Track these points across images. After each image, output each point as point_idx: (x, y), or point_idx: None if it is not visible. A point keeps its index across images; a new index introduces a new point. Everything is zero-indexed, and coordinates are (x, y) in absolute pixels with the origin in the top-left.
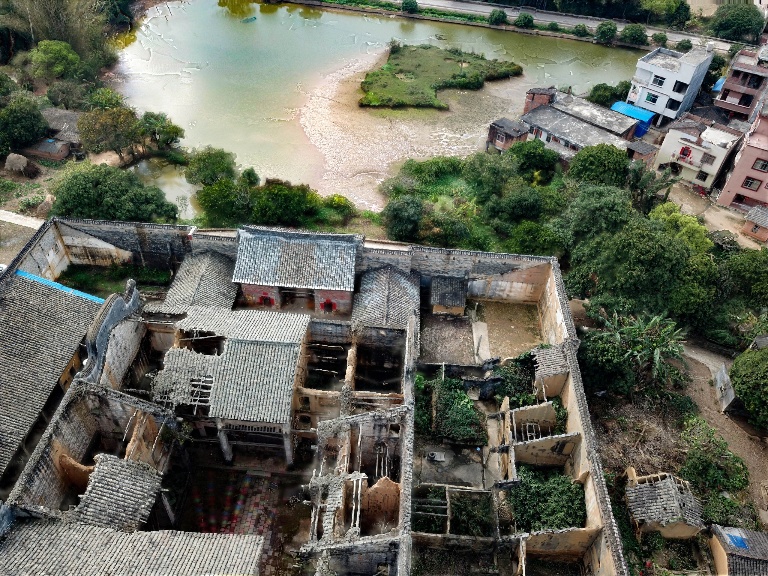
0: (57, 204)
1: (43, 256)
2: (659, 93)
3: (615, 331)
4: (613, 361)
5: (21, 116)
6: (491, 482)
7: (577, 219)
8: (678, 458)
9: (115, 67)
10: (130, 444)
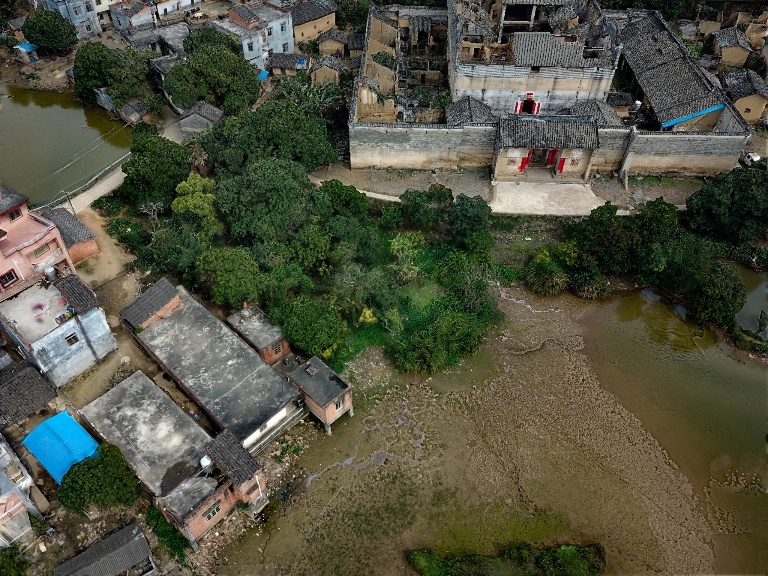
0: None
1: None
2: None
3: None
4: None
5: None
6: None
7: None
8: None
9: None
10: None
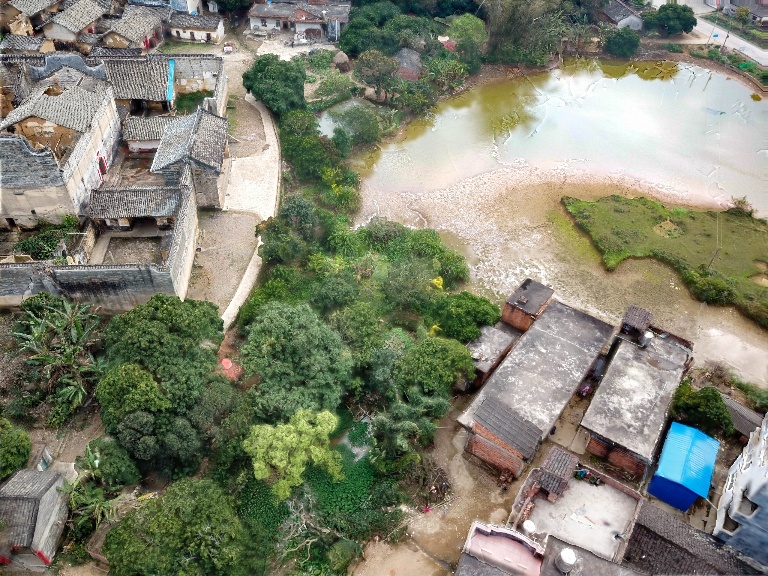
0: None
1: (201, 70)
2: (736, 477)
3: None
4: None
5: (368, 36)
6: None
7: None
8: None
9: (531, 70)
10: (1, 95)
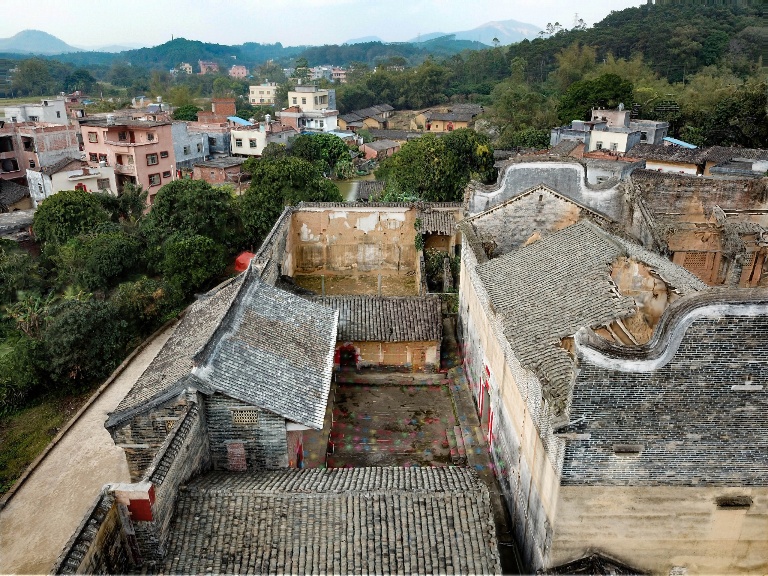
0: None
1: None
2: None
3: None
4: None
5: None
6: None
7: (196, 215)
8: None
9: None
10: None
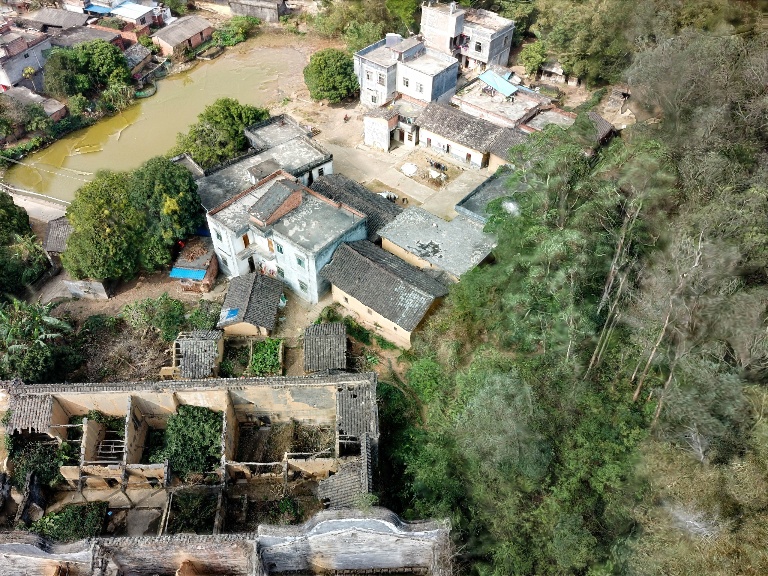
0: None
1: None
2: None
3: (4, 350)
4: (48, 356)
5: None
6: (153, 500)
7: None
8: (152, 338)
9: None
10: None
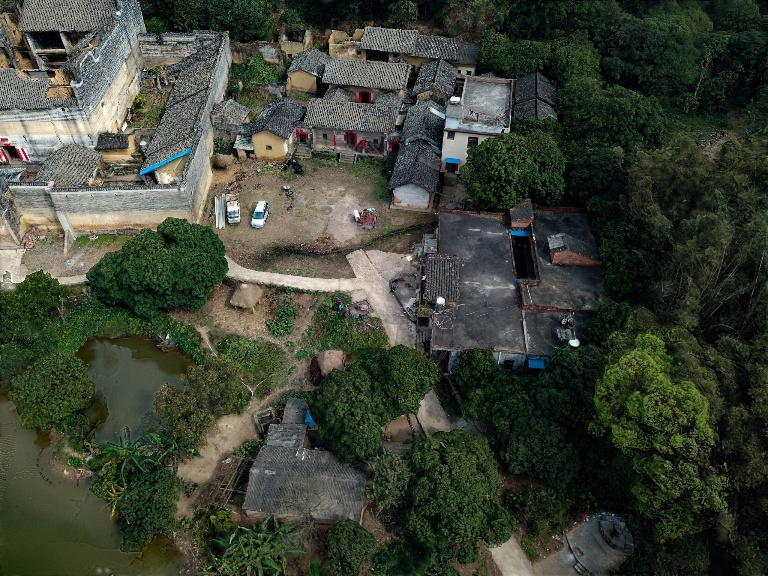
0: (202, 229)
1: None
2: None
3: None
4: None
5: (332, 379)
6: None
7: None
8: None
9: None
10: None
